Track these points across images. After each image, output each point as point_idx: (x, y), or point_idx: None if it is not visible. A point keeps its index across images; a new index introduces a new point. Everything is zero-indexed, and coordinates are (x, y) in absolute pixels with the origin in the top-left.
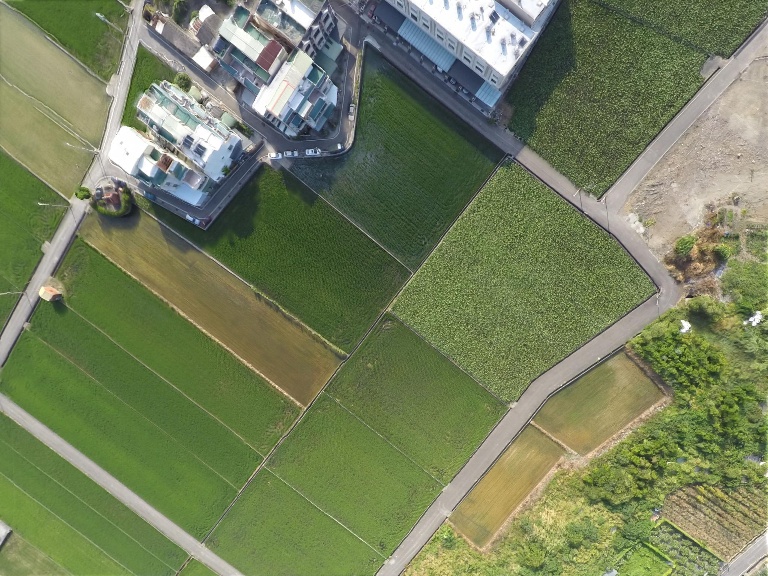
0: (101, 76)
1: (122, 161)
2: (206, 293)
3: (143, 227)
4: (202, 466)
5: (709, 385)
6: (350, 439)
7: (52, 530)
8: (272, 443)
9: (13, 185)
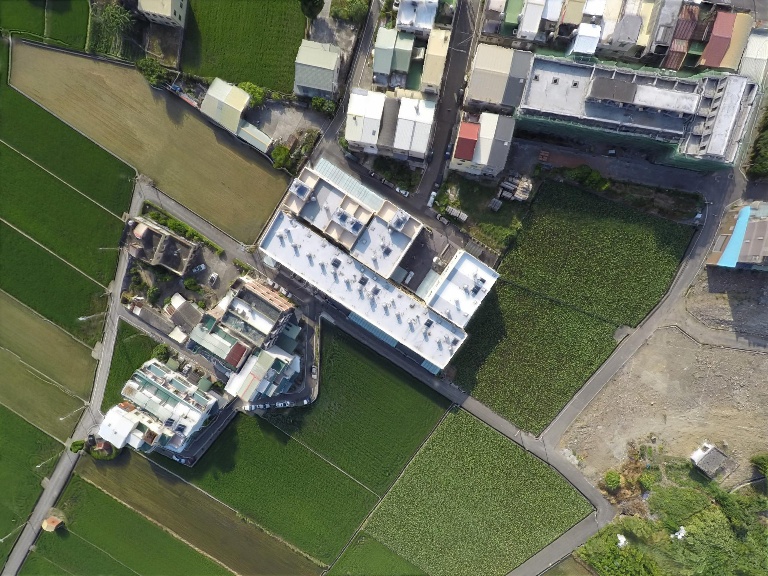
0: (86, 344)
1: (111, 439)
2: (196, 517)
3: (134, 464)
4: None
5: None
6: None
7: None
8: None
9: (11, 432)
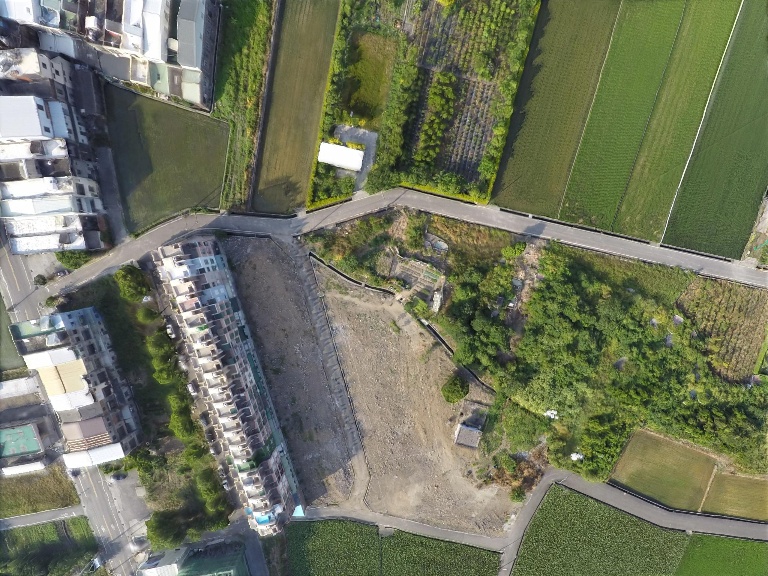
0: None
1: None
2: None
3: None
4: None
5: None
6: None
7: None
8: None
9: None
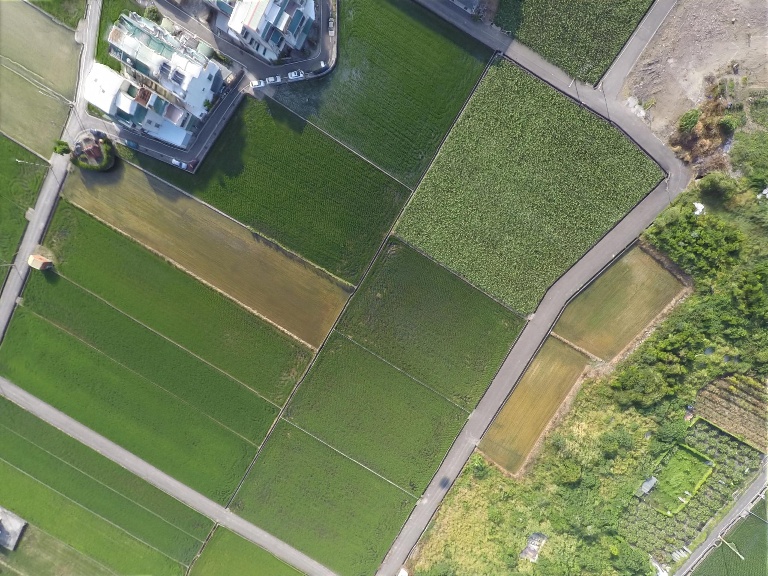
0: (68, 23)
1: (99, 100)
2: (202, 241)
3: (129, 179)
4: (217, 426)
5: (729, 266)
6: (367, 377)
7: (69, 516)
8: (287, 392)
9: None
